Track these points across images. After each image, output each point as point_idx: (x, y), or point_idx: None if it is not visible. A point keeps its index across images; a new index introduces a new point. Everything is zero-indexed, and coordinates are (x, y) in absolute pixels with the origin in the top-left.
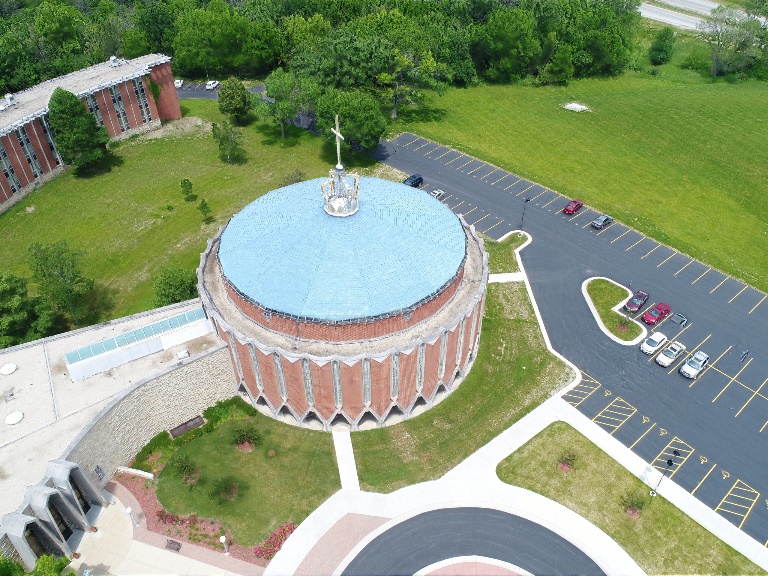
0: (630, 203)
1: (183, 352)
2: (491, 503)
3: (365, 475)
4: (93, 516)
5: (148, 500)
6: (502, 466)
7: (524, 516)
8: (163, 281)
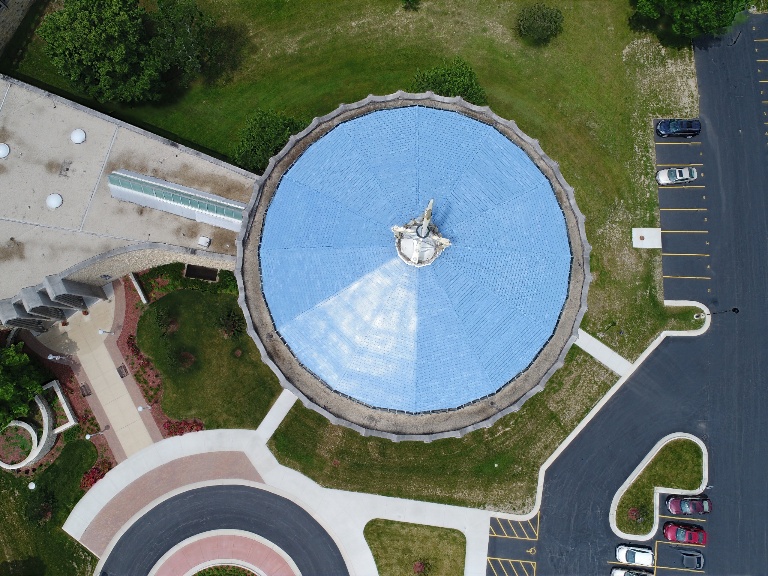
0: None
1: (205, 239)
2: (338, 539)
3: (280, 436)
4: (92, 300)
5: (131, 319)
6: (377, 523)
7: (349, 568)
8: (251, 129)
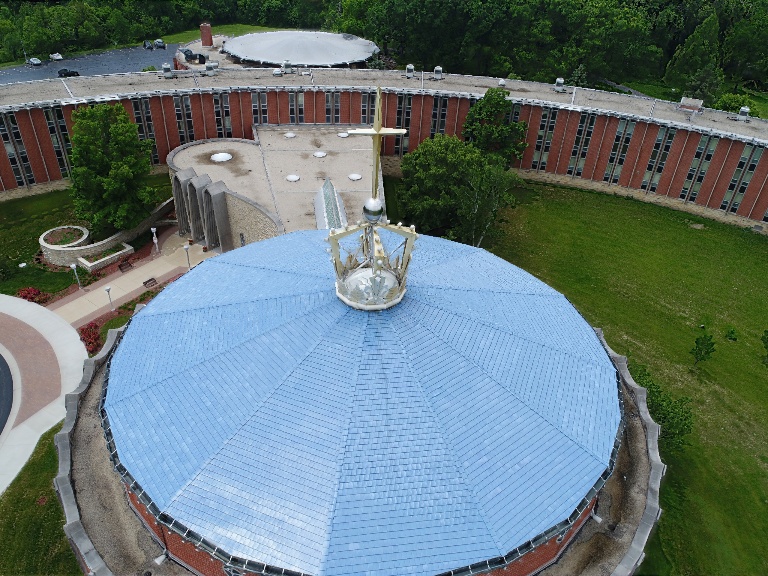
0: None
1: None
2: None
3: None
4: (220, 251)
5: None
6: None
7: None
8: None
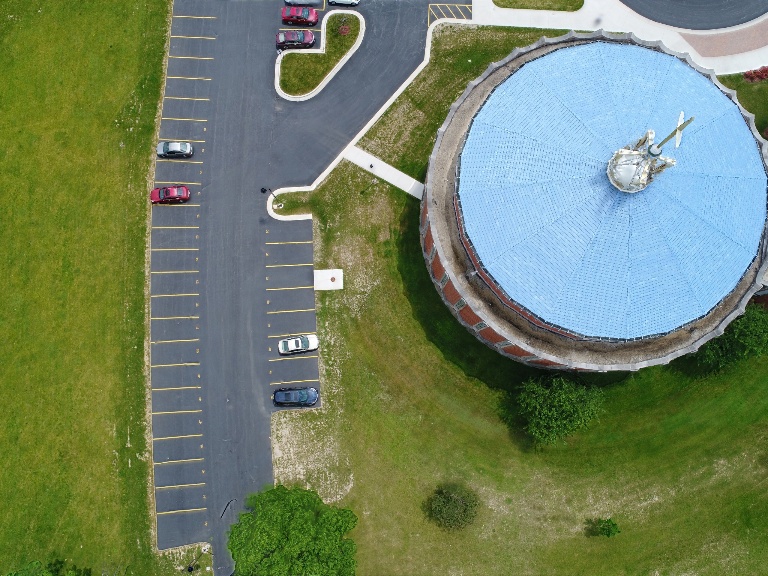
0: (95, 157)
1: None
2: None
3: None
4: None
5: None
6: (573, 8)
7: None
8: None
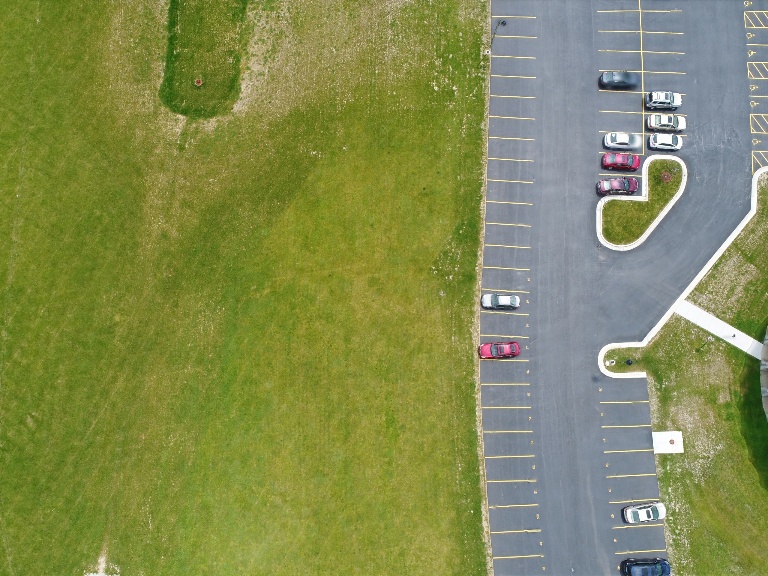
0: (413, 306)
1: None
2: None
3: None
4: None
5: None
6: None
7: None
8: None
